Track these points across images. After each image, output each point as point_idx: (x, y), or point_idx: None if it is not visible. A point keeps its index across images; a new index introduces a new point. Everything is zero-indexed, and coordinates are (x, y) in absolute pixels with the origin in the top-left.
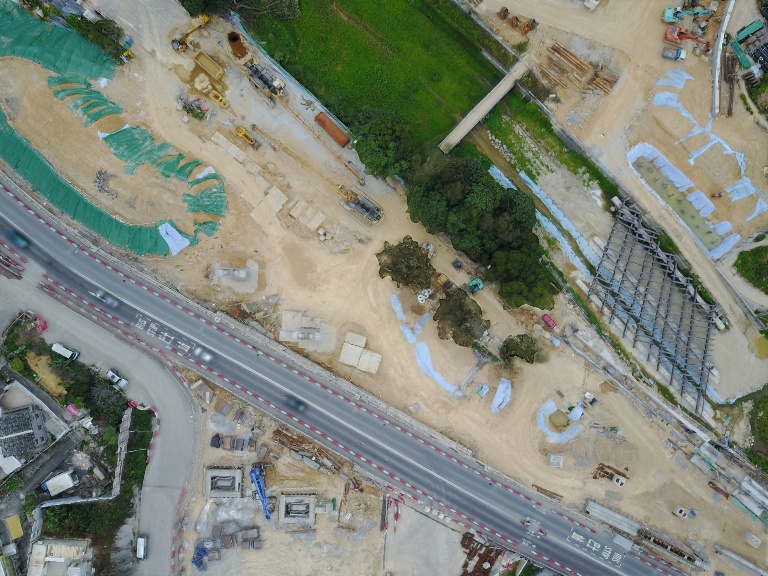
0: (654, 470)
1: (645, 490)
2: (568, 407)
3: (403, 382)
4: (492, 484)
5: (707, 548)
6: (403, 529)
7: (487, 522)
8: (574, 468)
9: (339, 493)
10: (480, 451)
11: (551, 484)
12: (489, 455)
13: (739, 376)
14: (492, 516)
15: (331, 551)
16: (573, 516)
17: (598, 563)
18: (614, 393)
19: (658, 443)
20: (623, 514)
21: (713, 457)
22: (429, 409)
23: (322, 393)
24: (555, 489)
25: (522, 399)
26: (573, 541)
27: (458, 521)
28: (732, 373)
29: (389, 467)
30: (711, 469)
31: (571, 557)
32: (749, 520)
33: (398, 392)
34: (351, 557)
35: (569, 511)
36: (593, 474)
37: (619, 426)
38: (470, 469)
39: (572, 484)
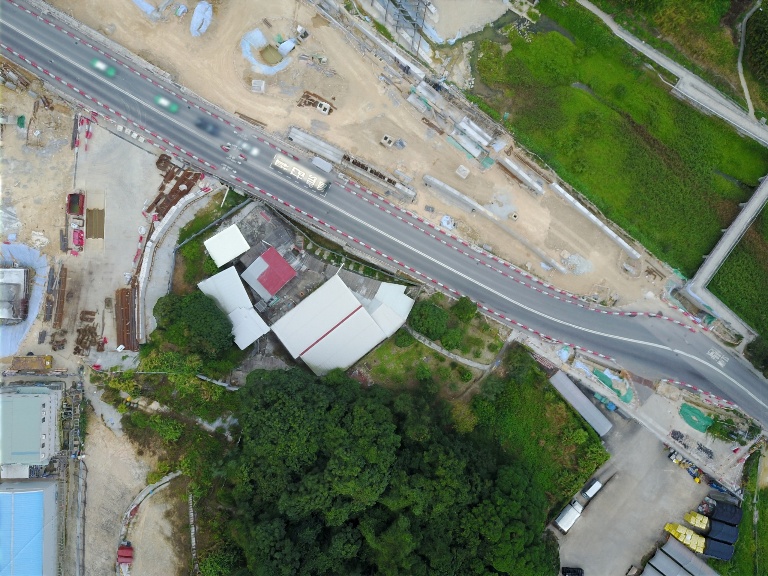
0: (365, 104)
1: (354, 121)
2: (279, 41)
3: (97, 2)
4: (191, 107)
5: (416, 180)
6: (96, 149)
7: (185, 146)
8: (278, 95)
9: (28, 111)
10: (180, 76)
11: (254, 112)
12: (190, 81)
13: (459, 15)
14: (191, 140)
15: (18, 168)
16: (276, 143)
17: (302, 191)
18: (326, 27)
19: (371, 78)
20: (329, 143)
21: (430, 97)
22: (126, 31)
23: (9, 8)
24: (259, 117)
25: (226, 26)
26: (276, 168)
27: (153, 142)
28: (452, 12)
29: (81, 86)
30: (428, 109)
31: (274, 184)
32: (462, 156)
33: (92, 12)
34: (39, 174)
35: (271, 137)
36: (298, 102)
37: (330, 59)
38: (166, 89)
39: (276, 112)
